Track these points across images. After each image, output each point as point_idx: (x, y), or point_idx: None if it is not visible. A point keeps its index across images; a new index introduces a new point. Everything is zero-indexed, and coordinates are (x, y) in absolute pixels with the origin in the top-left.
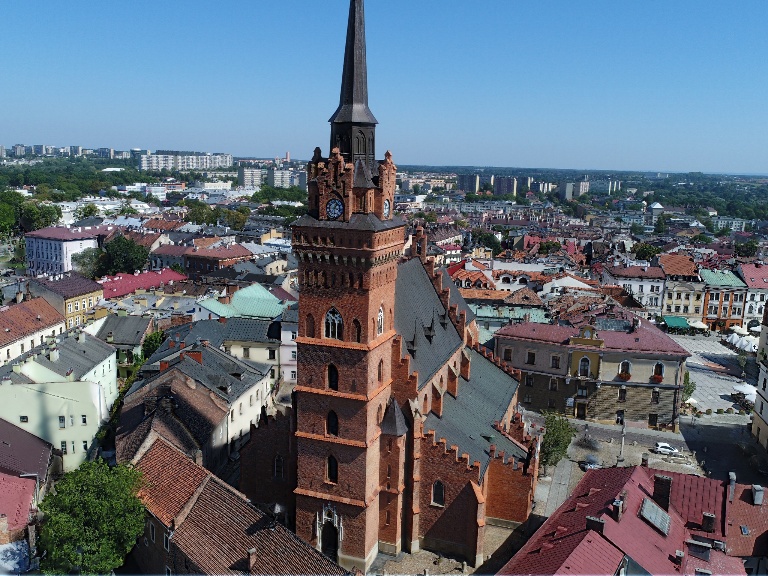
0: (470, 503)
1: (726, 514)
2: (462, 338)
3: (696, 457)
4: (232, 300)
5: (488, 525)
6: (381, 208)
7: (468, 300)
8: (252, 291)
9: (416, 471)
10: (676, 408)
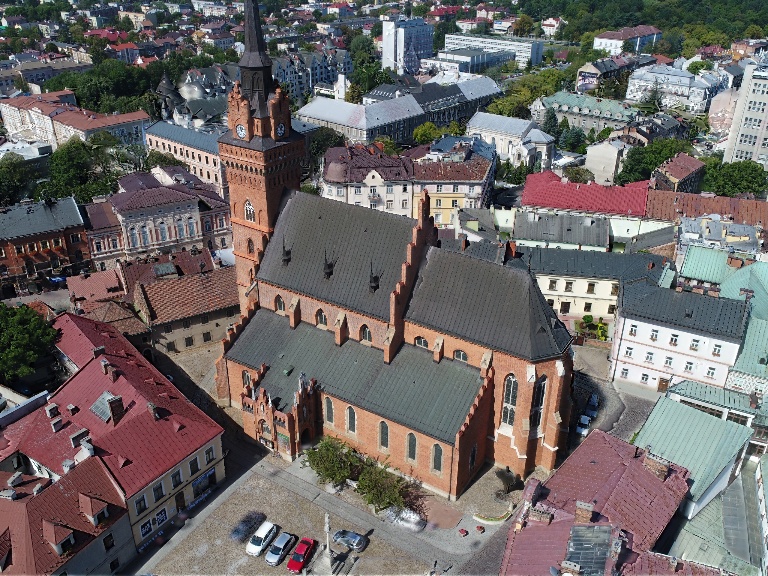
0: None
1: None
2: None
3: None
4: (745, 267)
5: None
6: (233, 129)
7: None
8: None
9: None
10: None
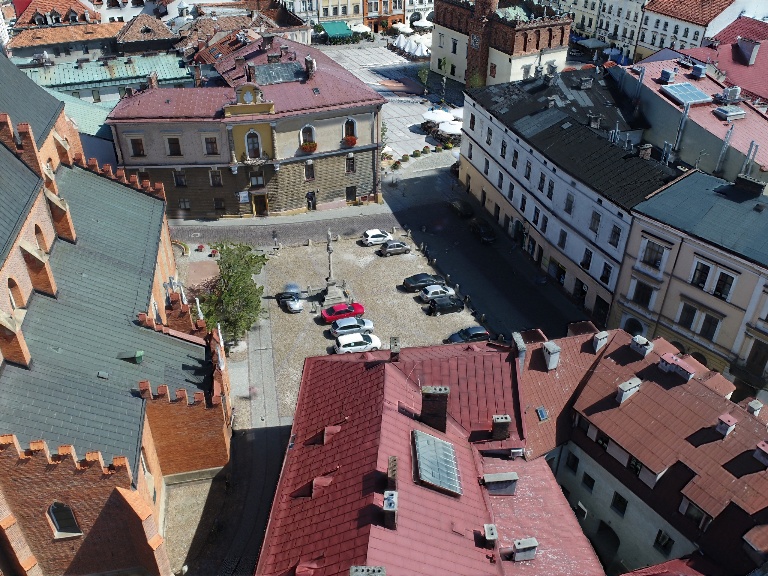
0: (127, 518)
1: (520, 405)
2: (38, 174)
3: (411, 236)
4: None
5: (170, 486)
6: None
7: (62, 45)
8: None
9: (1, 512)
10: (376, 173)
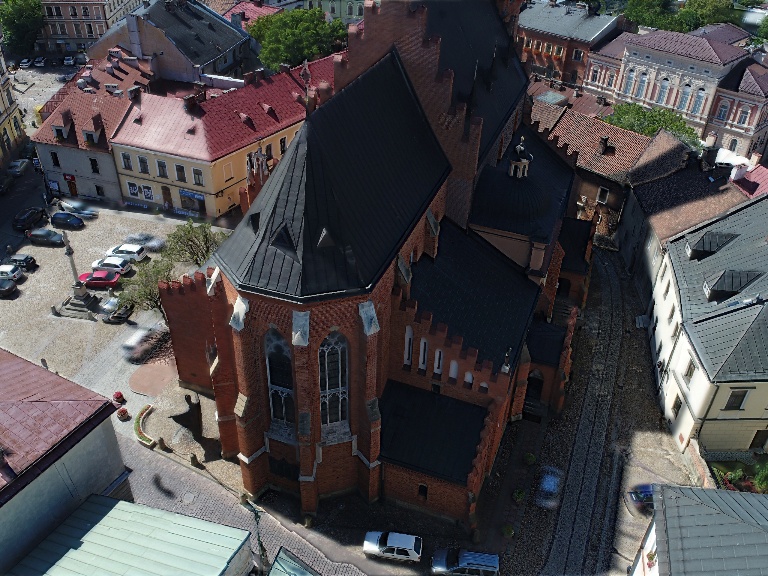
0: None
1: None
2: None
3: None
4: None
5: None
6: None
7: None
8: None
9: None
10: None
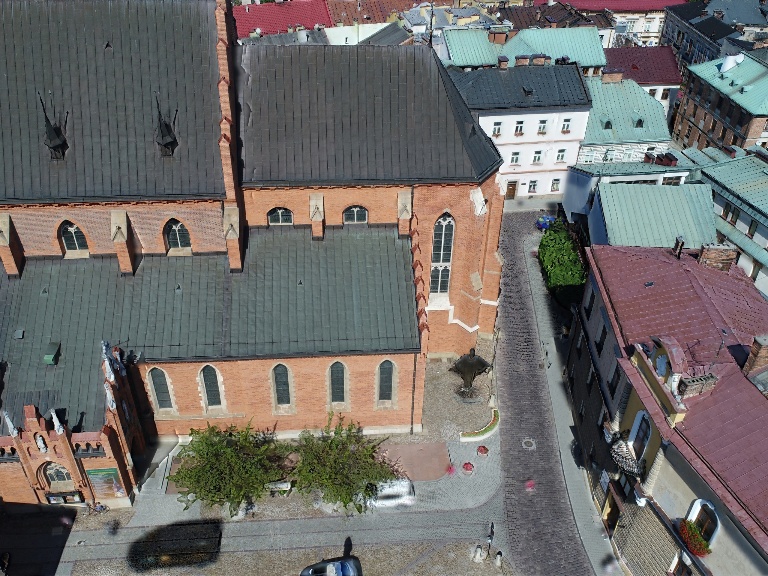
0: None
1: None
2: None
3: None
4: (510, 40)
5: None
6: None
7: None
8: (562, 36)
9: None
10: None
